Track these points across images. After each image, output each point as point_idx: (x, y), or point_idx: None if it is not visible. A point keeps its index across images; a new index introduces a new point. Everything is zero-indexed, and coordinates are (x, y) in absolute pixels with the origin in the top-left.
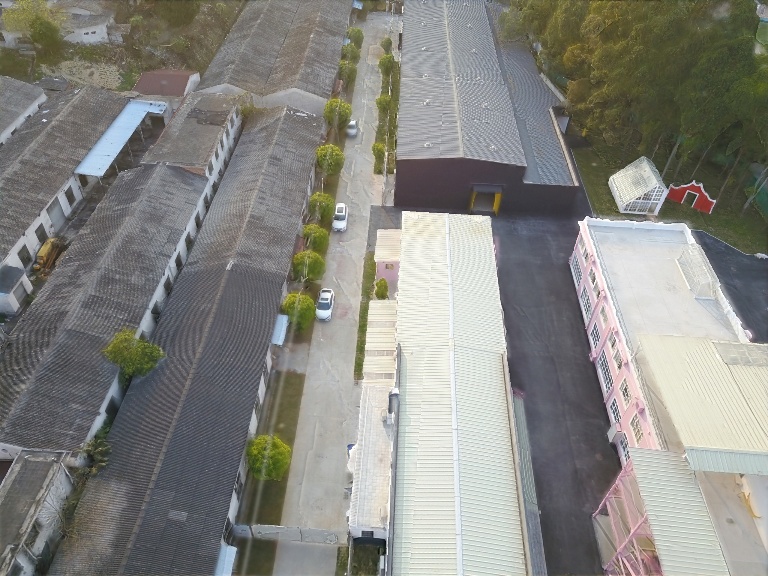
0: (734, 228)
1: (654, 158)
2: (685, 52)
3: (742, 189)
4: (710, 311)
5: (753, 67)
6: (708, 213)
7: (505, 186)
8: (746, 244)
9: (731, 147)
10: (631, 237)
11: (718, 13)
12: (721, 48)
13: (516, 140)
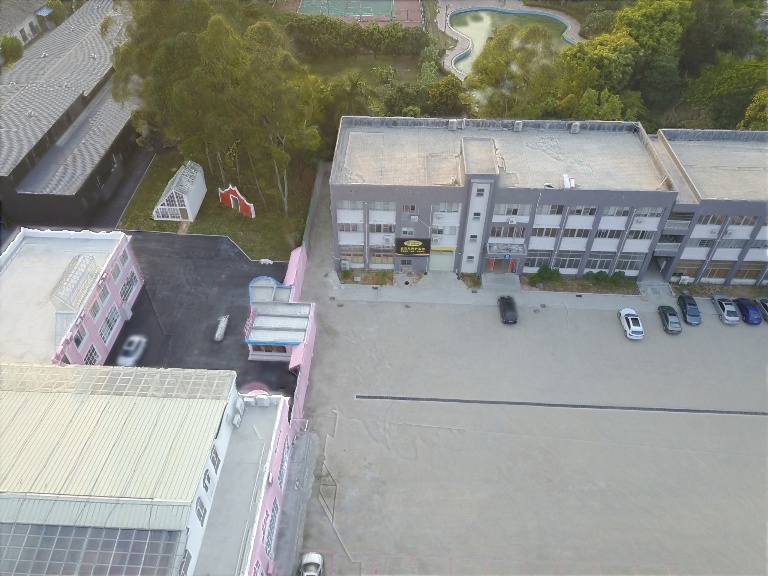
0: (266, 232)
1: (245, 161)
2: (145, 52)
3: (310, 190)
4: (57, 326)
5: (193, 66)
6: (251, 217)
7: (1, 197)
8: (263, 249)
9: (210, 149)
10: (59, 248)
11: (169, 10)
12: (160, 47)
13: (25, 148)
